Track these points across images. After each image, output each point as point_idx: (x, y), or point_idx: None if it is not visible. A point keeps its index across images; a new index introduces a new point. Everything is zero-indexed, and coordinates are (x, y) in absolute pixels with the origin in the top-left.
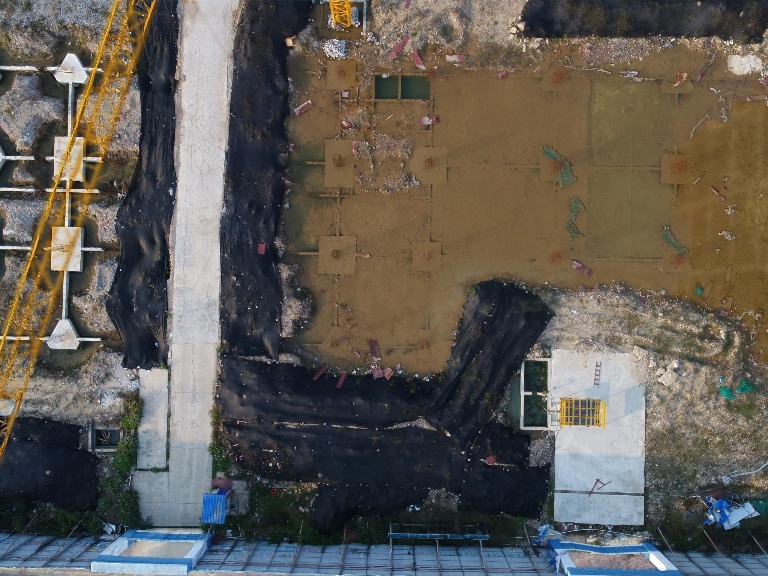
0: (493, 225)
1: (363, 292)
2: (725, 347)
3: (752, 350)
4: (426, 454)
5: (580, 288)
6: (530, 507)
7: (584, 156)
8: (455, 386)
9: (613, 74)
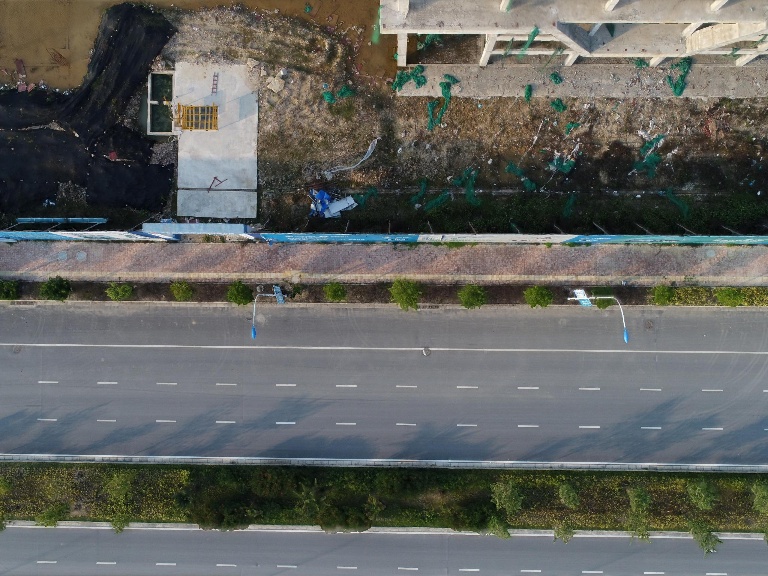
0: None
1: (10, 17)
2: (330, 58)
3: (355, 61)
4: (55, 151)
5: (202, 9)
6: (153, 201)
7: None
8: (86, 94)
9: None
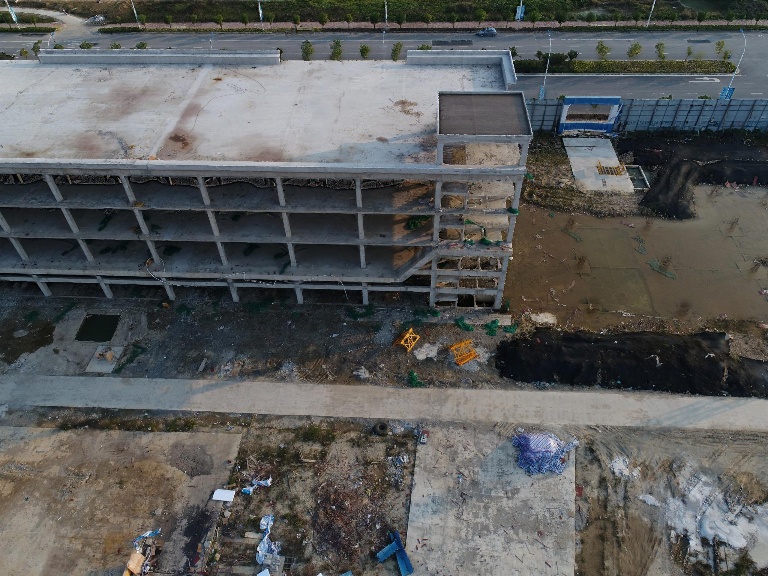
0: (693, 243)
1: (763, 216)
2: None
3: None
4: (694, 152)
5: (626, 216)
6: None
7: (645, 273)
8: None
9: (640, 315)
